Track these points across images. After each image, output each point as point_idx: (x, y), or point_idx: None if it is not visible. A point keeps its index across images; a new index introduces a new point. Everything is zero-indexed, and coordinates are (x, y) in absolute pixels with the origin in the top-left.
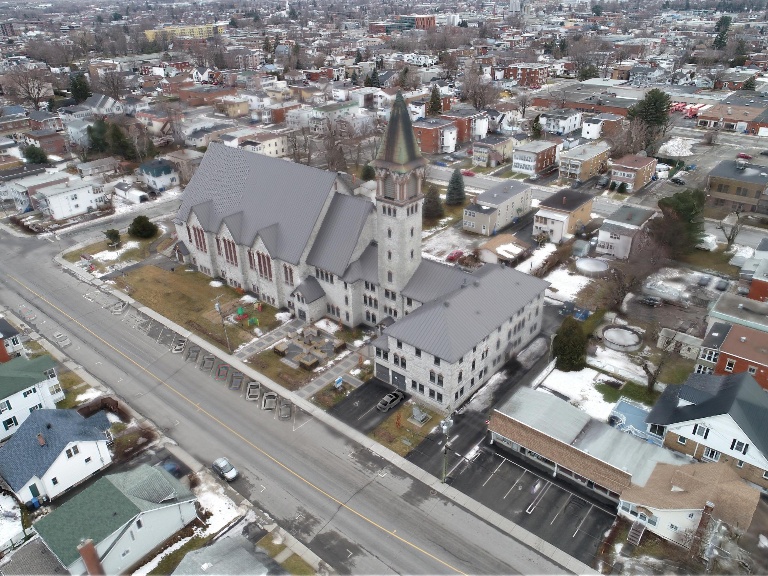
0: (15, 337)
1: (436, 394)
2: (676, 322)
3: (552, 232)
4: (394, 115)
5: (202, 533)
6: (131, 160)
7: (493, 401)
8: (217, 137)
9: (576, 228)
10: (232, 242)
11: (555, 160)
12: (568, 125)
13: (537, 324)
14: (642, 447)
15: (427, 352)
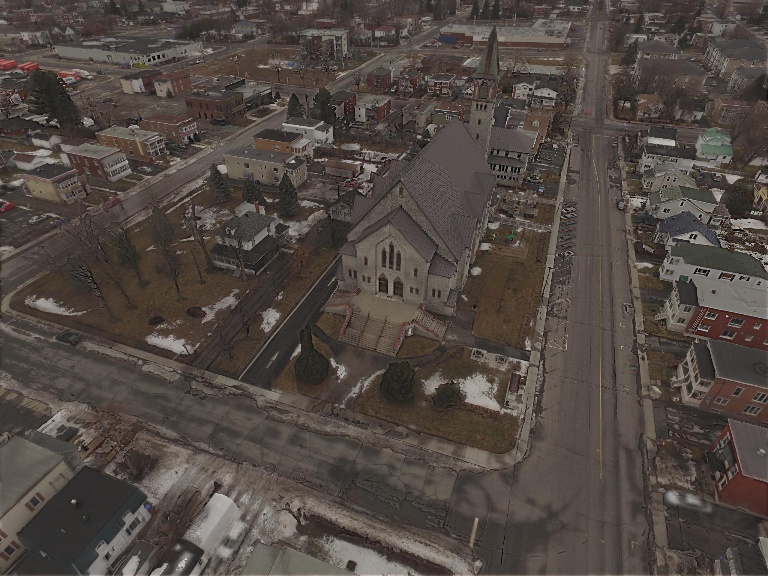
0: None
1: None
2: None
3: None
4: None
5: None
6: None
7: None
8: None
9: None
10: None
11: None
12: None
13: None
14: None
15: None
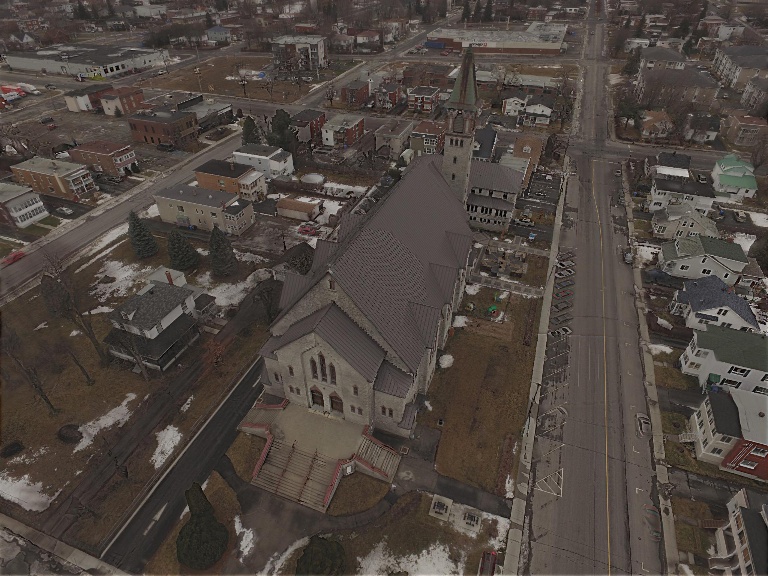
0: None
1: None
2: None
3: None
4: None
5: None
6: None
7: None
8: None
9: None
10: None
11: None
12: None
13: None
14: None
15: None
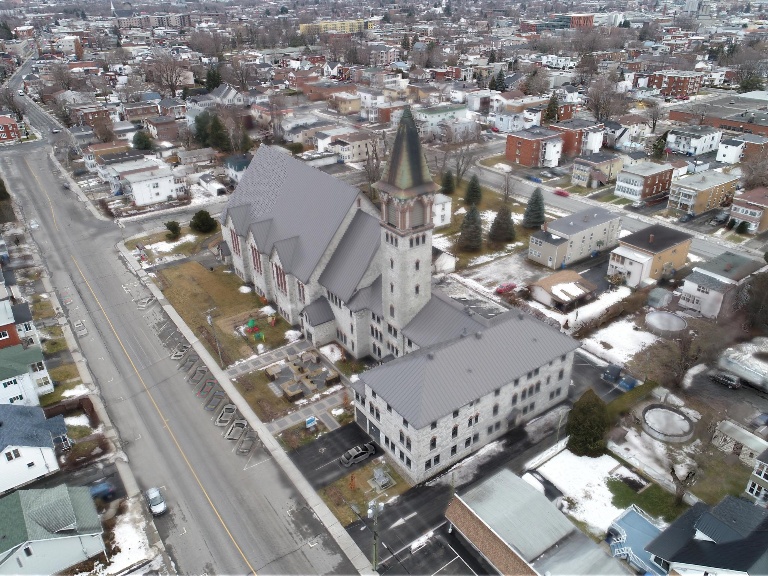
0: (28, 323)
1: (405, 458)
2: (751, 413)
3: (629, 274)
4: (400, 133)
5: (101, 571)
6: (228, 152)
7: (475, 477)
8: (314, 134)
9: (663, 272)
10: (257, 250)
11: (670, 186)
12: (702, 145)
13: (562, 389)
14: None
15: (395, 410)
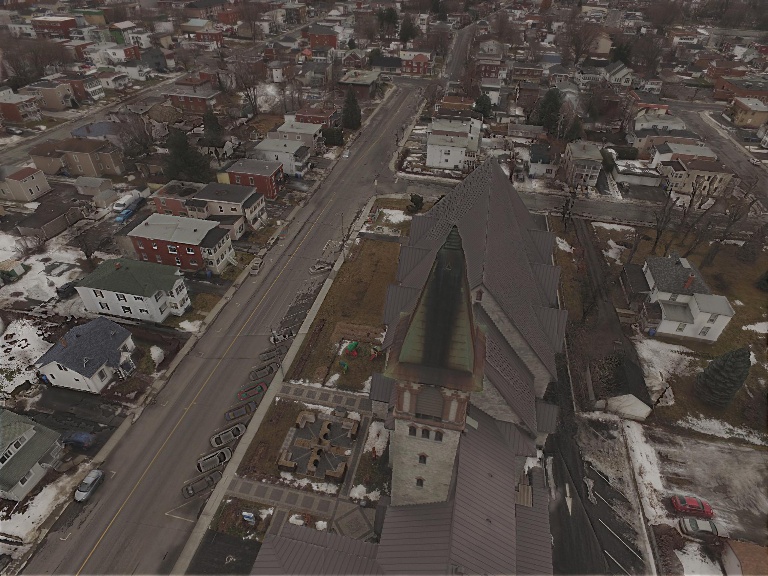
0: (210, 249)
1: None
2: None
3: None
4: None
5: None
6: None
7: None
8: (663, 143)
9: None
10: None
11: None
12: None
13: None
14: None
15: None
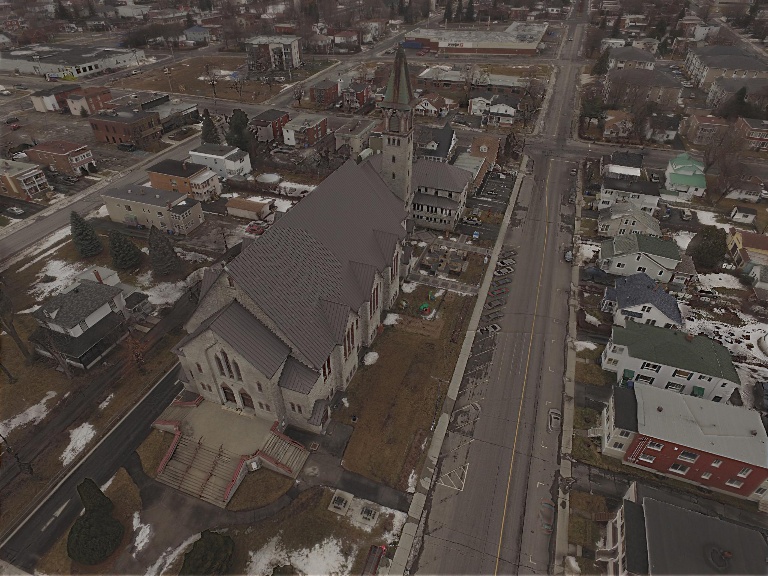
0: None
1: None
2: None
3: None
4: None
5: None
6: None
7: None
8: None
9: None
10: None
11: None
12: None
13: None
14: (462, 159)
15: None
